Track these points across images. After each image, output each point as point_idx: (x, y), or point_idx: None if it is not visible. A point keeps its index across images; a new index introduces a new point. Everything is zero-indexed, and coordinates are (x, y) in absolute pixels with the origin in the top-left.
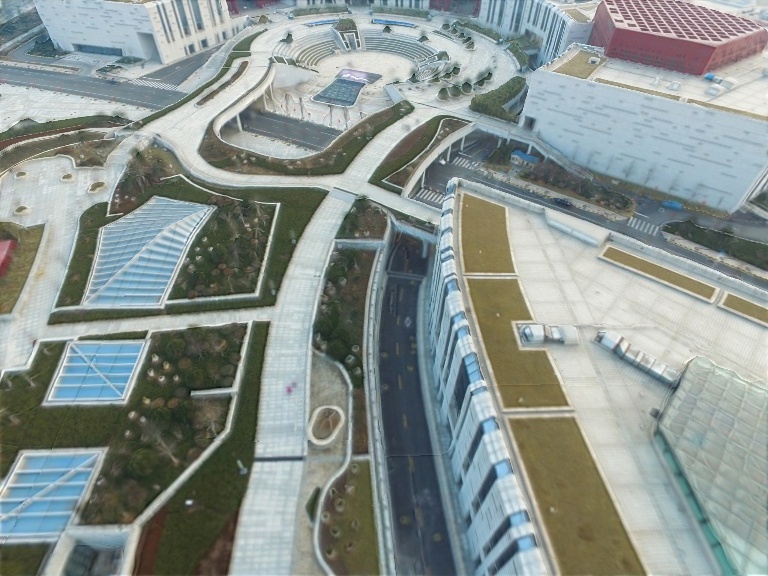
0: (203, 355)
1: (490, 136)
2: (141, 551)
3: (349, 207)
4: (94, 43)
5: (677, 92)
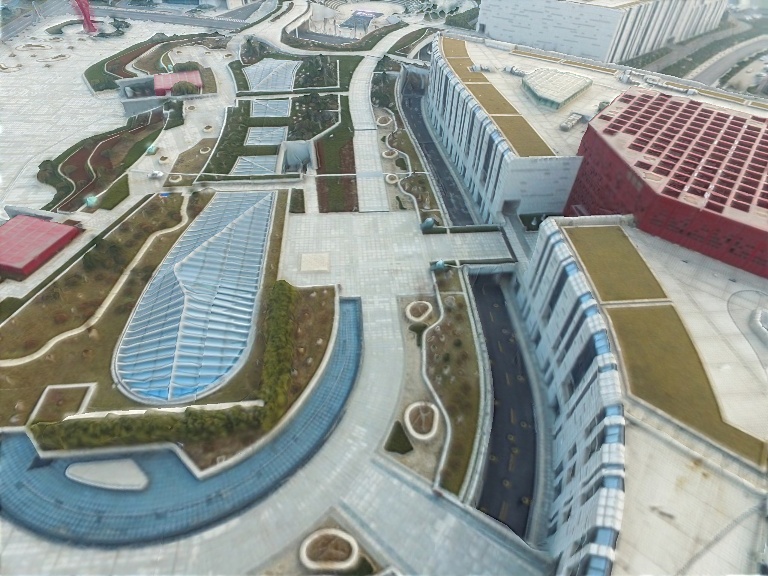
0: (321, 102)
1: None
2: (317, 145)
3: None
4: None
5: None
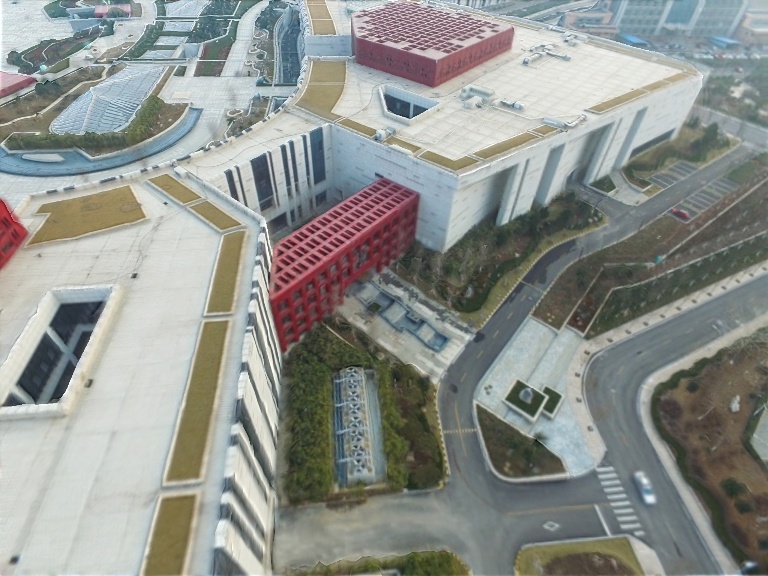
0: None
1: None
2: None
3: None
4: None
5: None
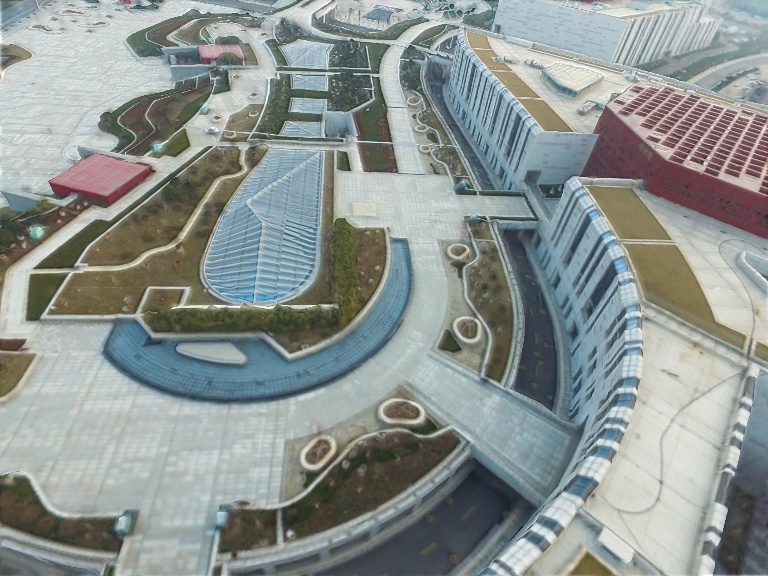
0: None
1: None
2: None
3: None
4: None
5: (577, 7)
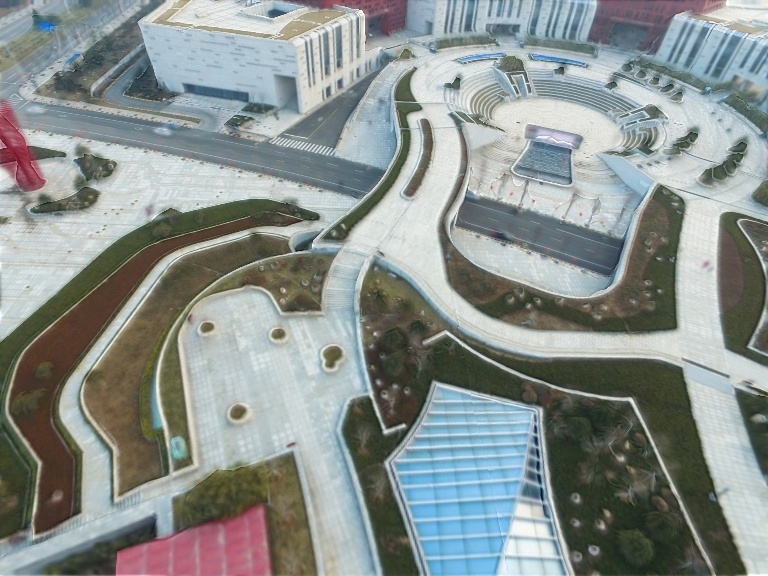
0: None
1: None
2: None
3: (735, 405)
4: (212, 84)
5: None
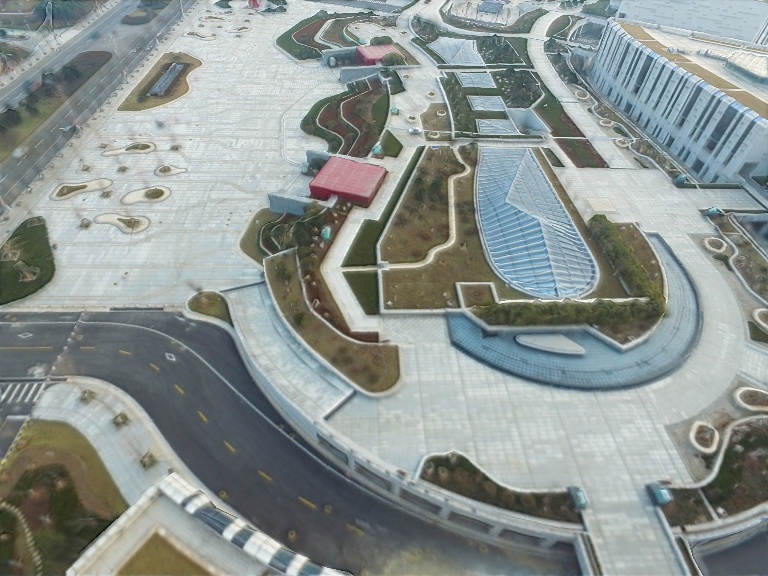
0: (519, 76)
1: (597, 26)
2: None
3: (543, 44)
4: None
5: None
